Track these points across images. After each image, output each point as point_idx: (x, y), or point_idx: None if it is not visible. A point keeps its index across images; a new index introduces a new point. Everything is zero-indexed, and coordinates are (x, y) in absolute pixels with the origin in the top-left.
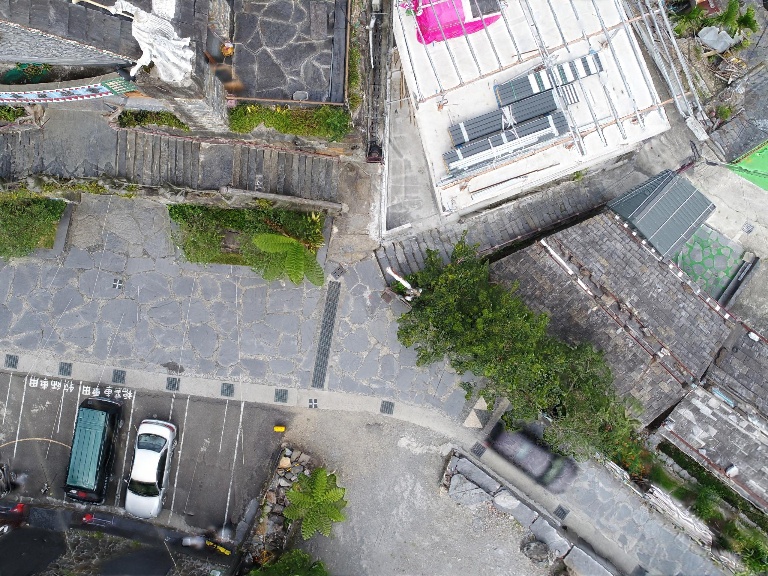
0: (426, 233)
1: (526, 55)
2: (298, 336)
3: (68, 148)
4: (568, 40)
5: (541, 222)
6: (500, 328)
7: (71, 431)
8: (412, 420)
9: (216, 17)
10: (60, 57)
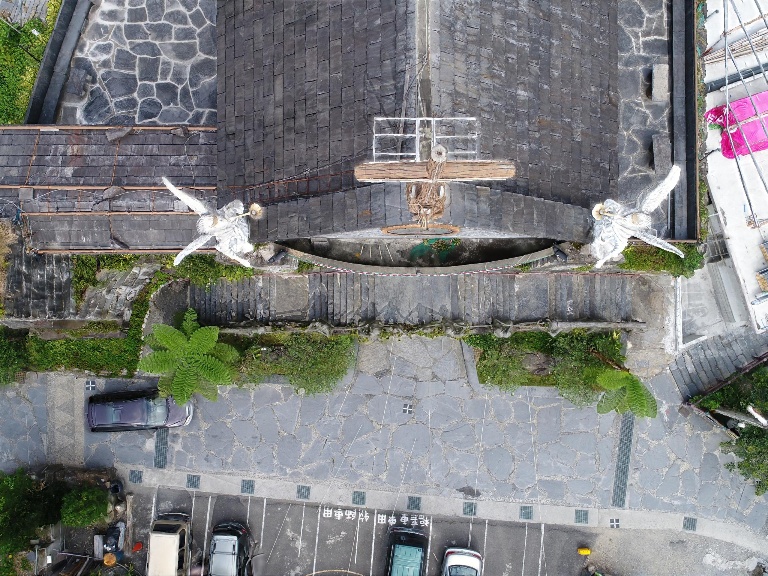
0: (709, 340)
1: None
2: (596, 455)
3: (401, 292)
4: None
5: None
6: None
7: (369, 561)
8: (716, 536)
9: None
10: None
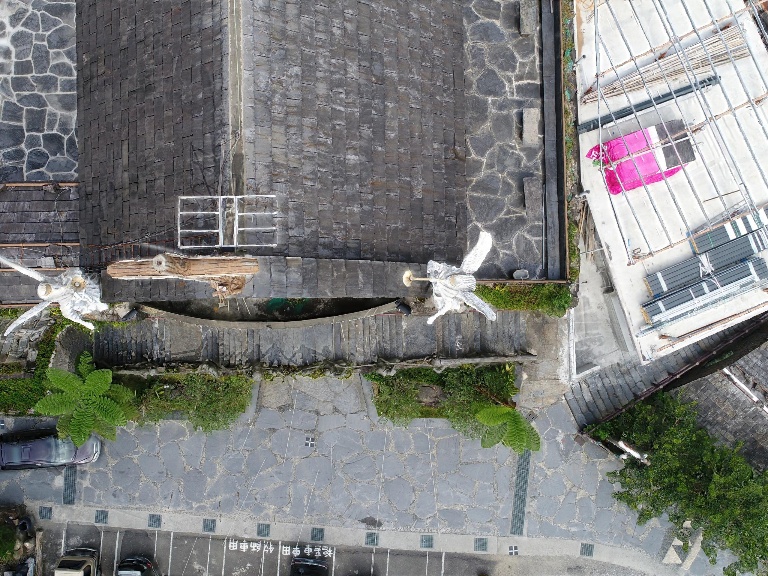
0: (607, 368)
1: (717, 200)
2: (494, 484)
3: (284, 334)
4: (759, 182)
5: (710, 341)
6: (734, 494)
7: None
8: (612, 561)
9: None
10: None
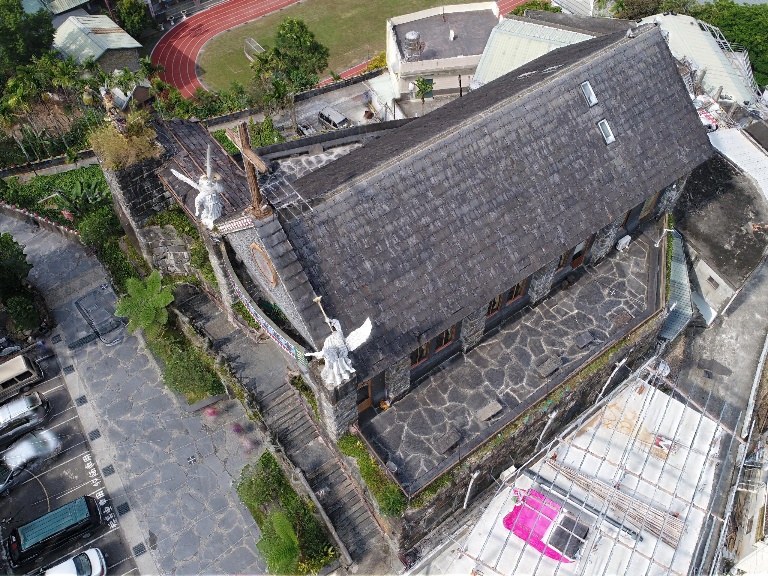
0: None
1: None
2: None
3: (256, 365)
4: None
5: None
6: None
7: None
8: None
9: (392, 381)
10: (293, 319)
